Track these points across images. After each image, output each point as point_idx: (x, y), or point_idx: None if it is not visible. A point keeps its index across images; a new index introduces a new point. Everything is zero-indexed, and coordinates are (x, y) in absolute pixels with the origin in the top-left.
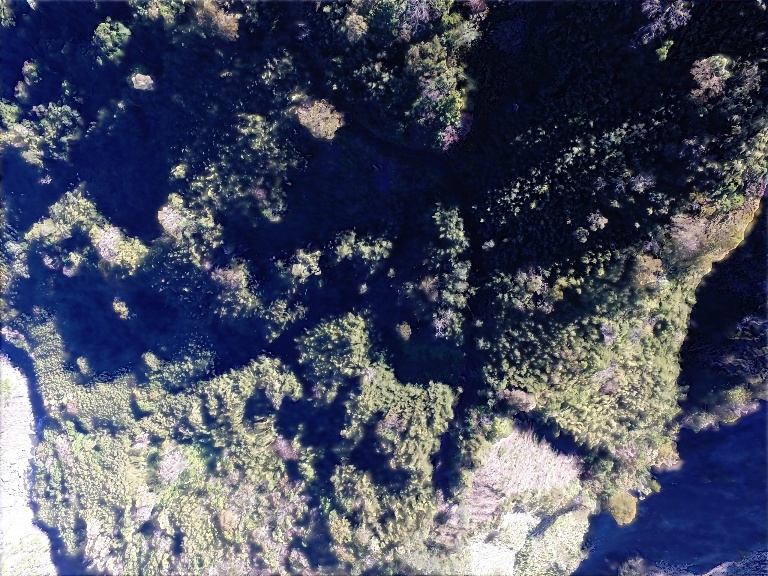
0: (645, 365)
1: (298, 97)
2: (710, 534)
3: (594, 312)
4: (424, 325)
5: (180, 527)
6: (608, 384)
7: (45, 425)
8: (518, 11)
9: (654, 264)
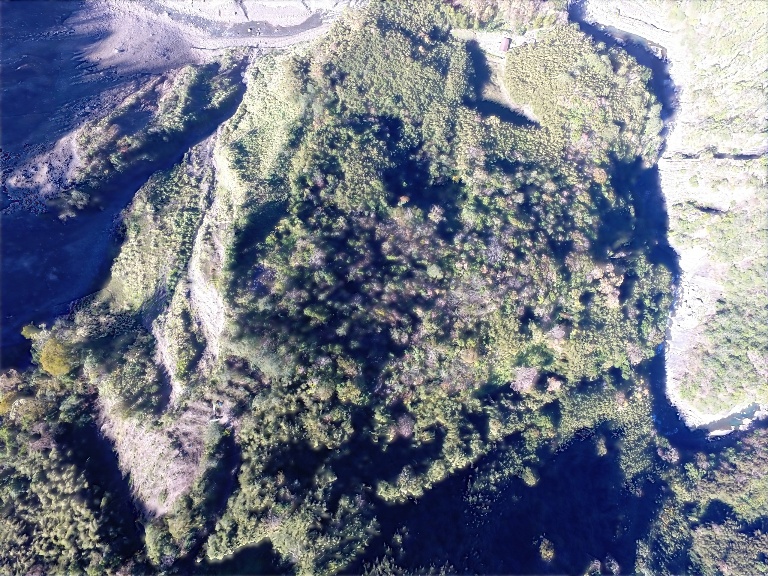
0: None
1: None
2: None
3: None
4: None
5: None
6: None
7: None
8: None
9: None
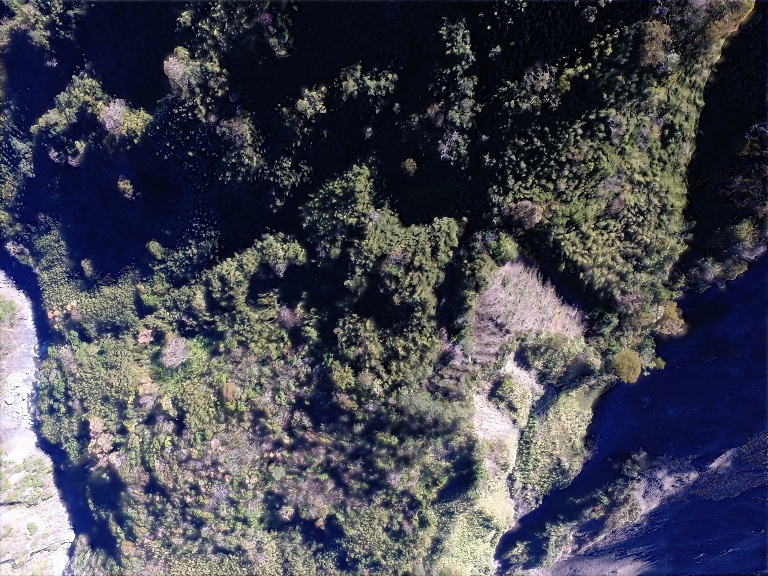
0: (652, 183)
1: None
2: (715, 418)
3: (601, 103)
4: (429, 160)
5: (183, 406)
6: (614, 201)
7: (49, 342)
8: None
9: (663, 29)
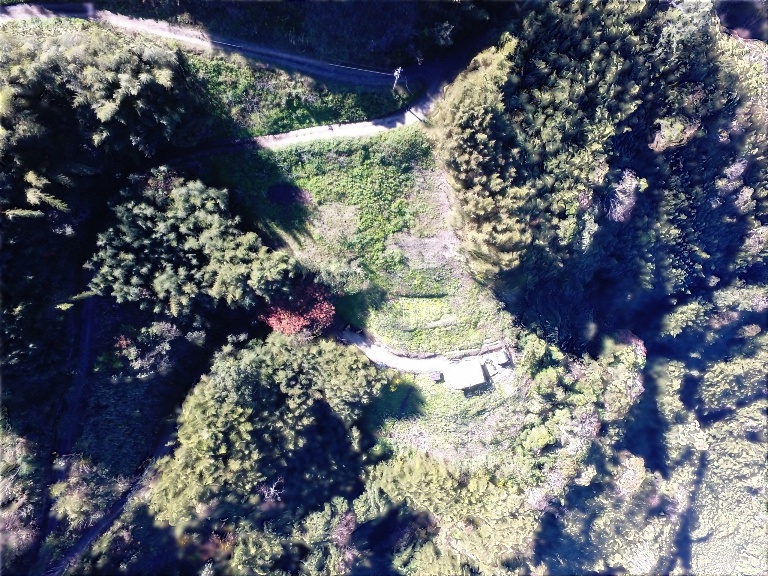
0: None
1: (605, 499)
2: None
3: None
4: None
5: None
6: None
7: None
8: (567, 325)
9: None
